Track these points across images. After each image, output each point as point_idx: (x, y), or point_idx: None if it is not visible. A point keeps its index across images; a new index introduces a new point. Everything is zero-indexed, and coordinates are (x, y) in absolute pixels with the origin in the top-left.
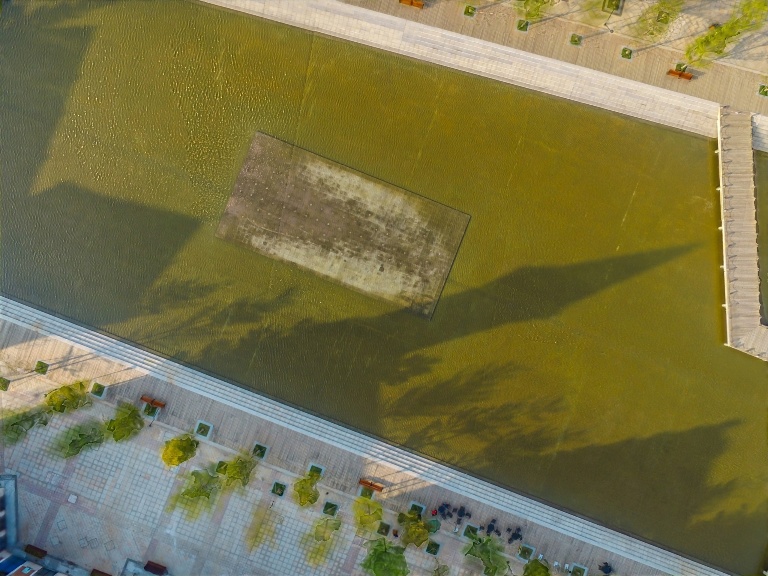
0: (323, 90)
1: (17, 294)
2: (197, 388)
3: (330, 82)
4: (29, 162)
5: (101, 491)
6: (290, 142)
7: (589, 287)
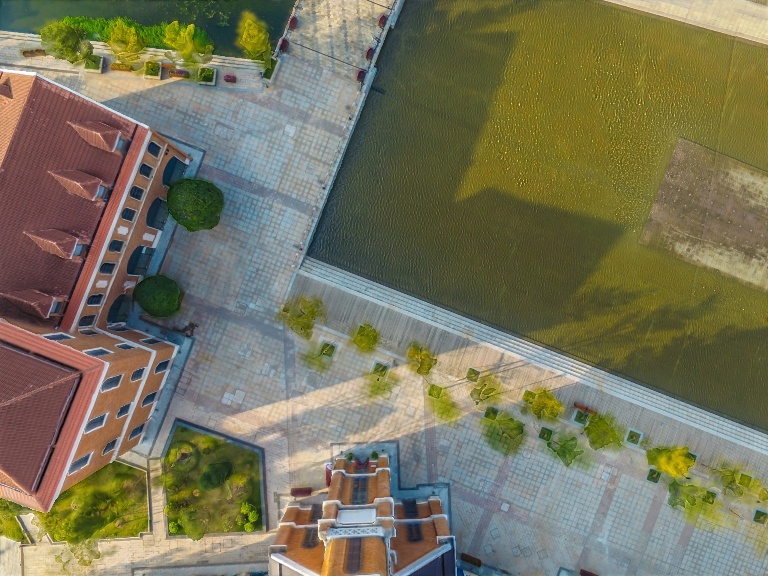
0: (744, 96)
1: (442, 301)
2: (627, 396)
3: (751, 88)
4: (453, 168)
5: (533, 499)
6: (712, 148)
7: None
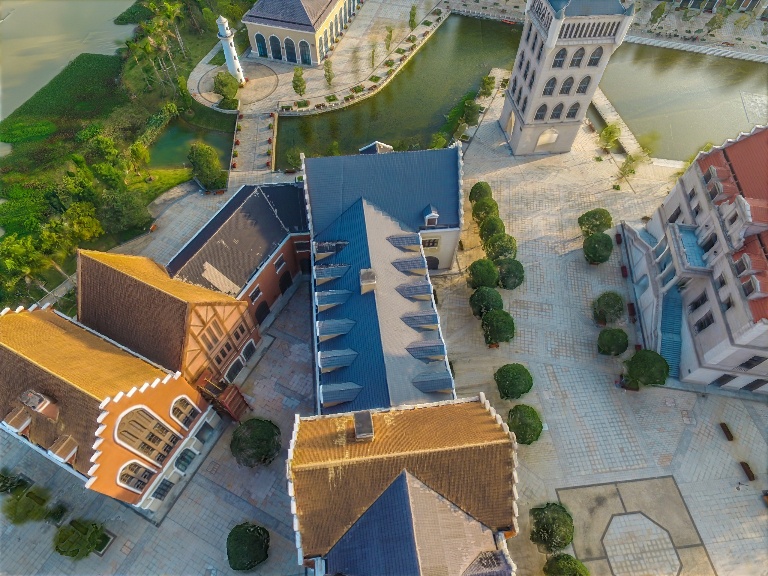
0: None
1: None
2: None
3: None
4: None
5: None
6: None
7: (672, 104)
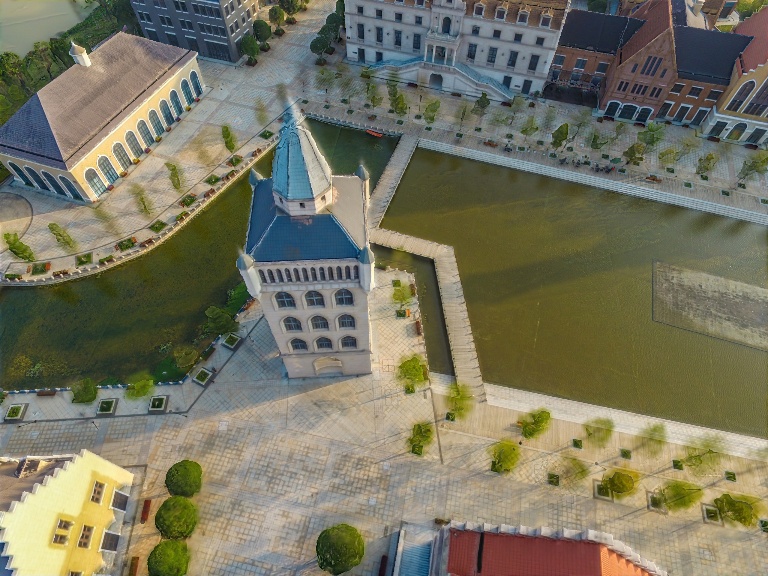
0: None
1: None
2: None
3: None
4: None
5: None
6: None
7: (552, 280)
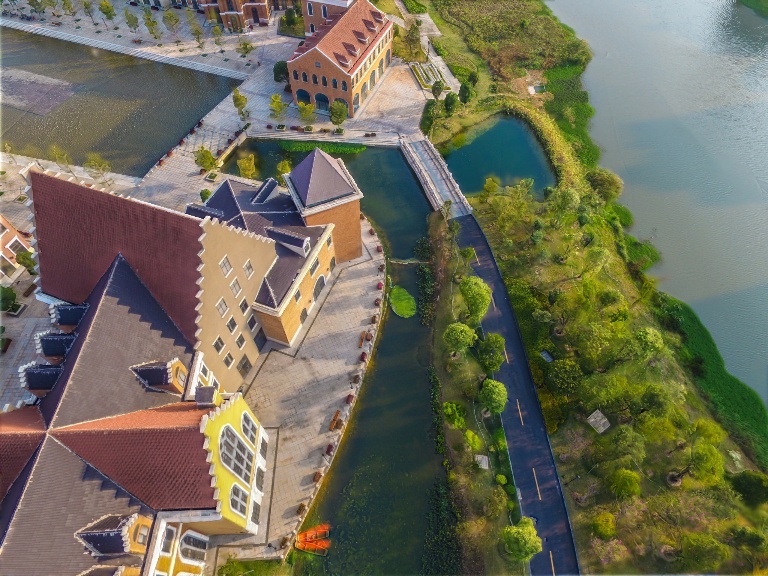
0: None
1: None
2: (116, 46)
3: None
4: None
5: None
6: None
7: None
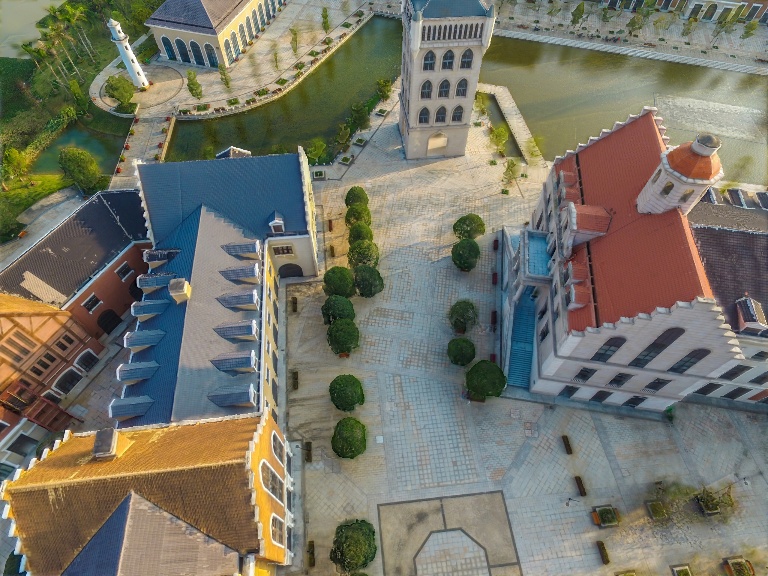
0: None
1: None
2: (746, 67)
3: None
4: None
5: (760, 40)
6: None
7: (582, 106)
